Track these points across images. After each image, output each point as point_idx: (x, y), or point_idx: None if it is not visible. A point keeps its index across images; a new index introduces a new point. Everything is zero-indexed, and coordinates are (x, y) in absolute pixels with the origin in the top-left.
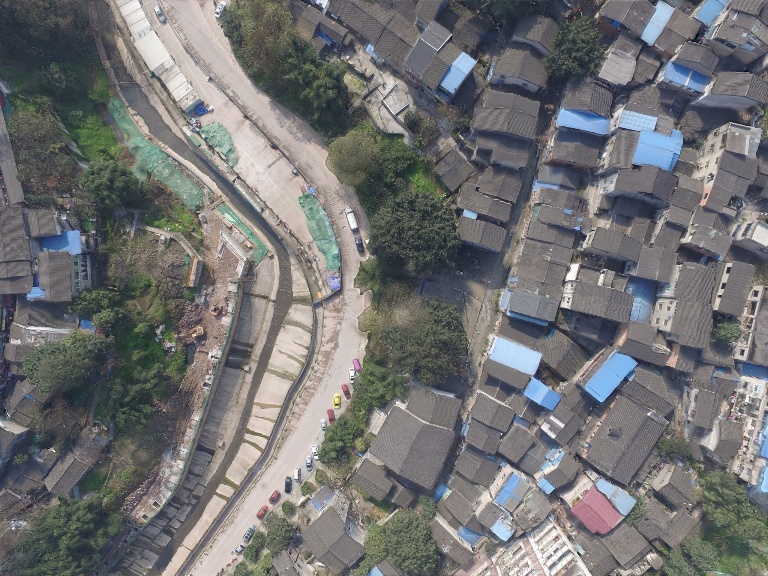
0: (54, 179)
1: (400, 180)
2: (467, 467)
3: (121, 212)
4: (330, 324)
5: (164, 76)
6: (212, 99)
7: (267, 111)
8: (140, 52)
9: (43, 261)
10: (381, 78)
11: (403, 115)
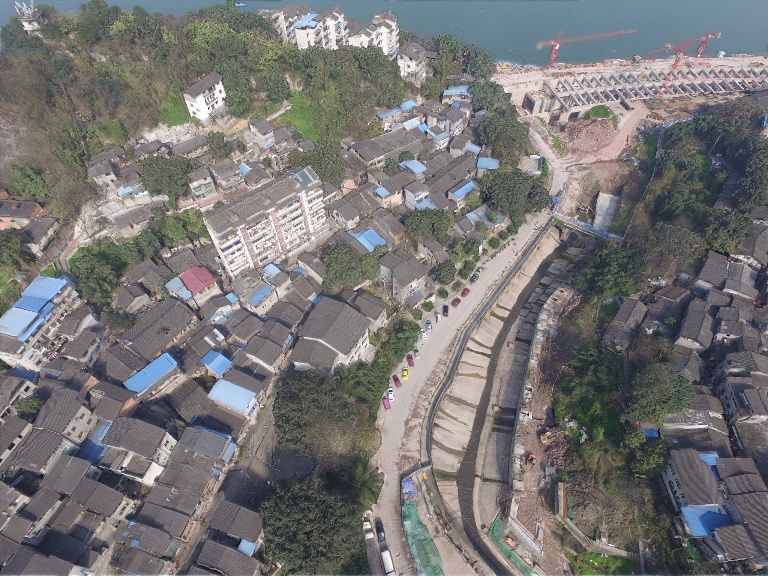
0: None
1: None
2: (293, 313)
3: None
4: (413, 444)
5: None
6: None
7: None
8: None
9: (716, 494)
10: None
11: None
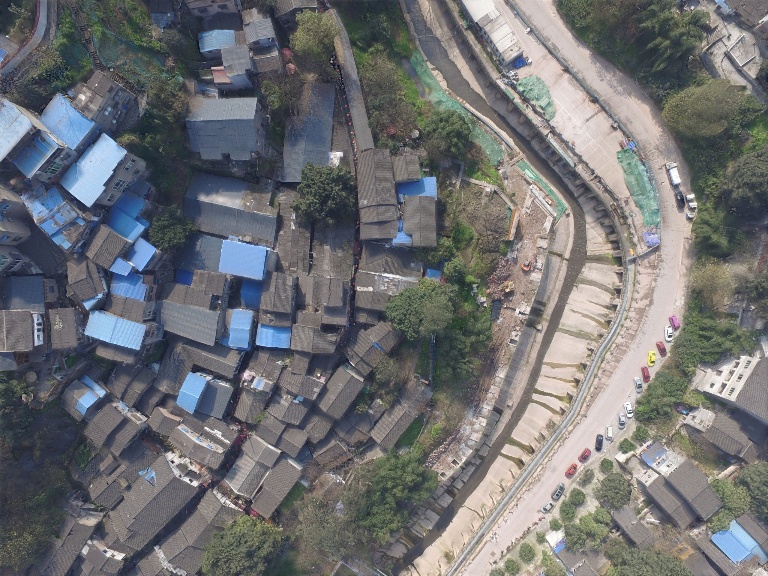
0: (398, 126)
1: (746, 132)
2: None
3: (447, 163)
4: (645, 281)
5: (488, 27)
6: (530, 52)
7: (587, 64)
8: (464, 2)
9: (411, 206)
10: (725, 29)
11: (748, 67)
